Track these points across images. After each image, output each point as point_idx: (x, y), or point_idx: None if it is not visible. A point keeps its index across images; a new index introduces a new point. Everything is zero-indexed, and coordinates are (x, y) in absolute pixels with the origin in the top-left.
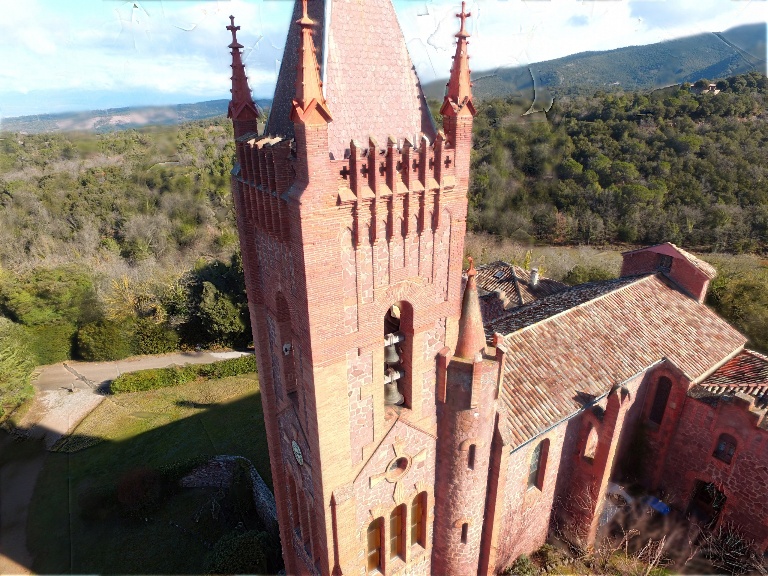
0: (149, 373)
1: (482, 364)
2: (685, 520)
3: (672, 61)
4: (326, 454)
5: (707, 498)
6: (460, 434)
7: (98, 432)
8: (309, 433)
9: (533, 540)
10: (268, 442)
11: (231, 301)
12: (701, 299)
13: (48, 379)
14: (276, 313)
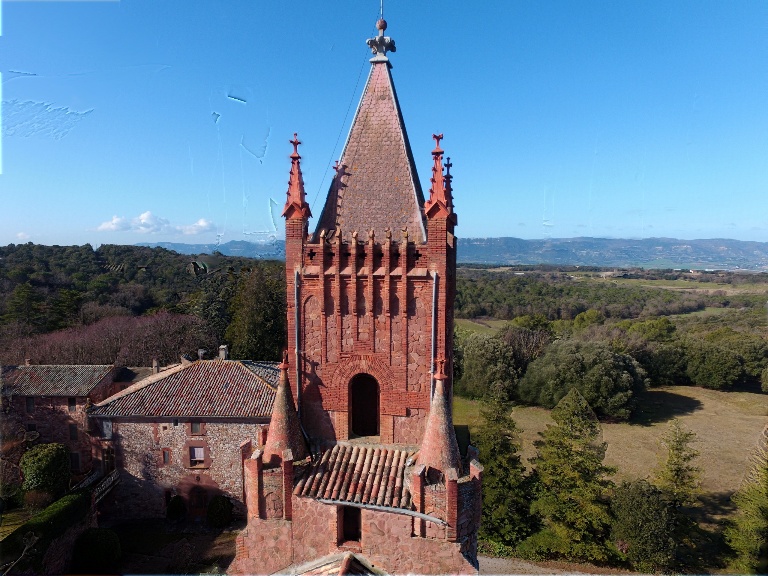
0: None
1: (259, 439)
2: None
3: None
4: None
5: None
6: None
7: None
8: None
9: None
10: None
11: None
12: None
13: None
14: None
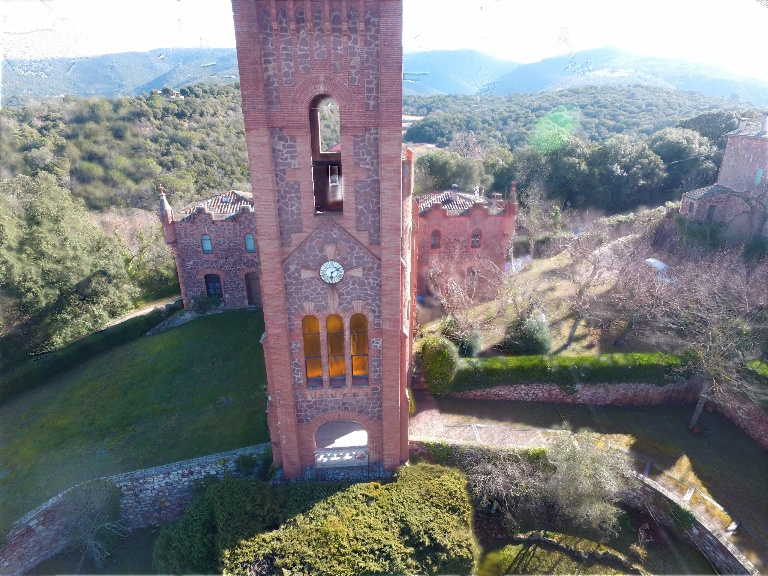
0: None
1: None
2: (429, 298)
3: (206, 42)
4: None
5: (429, 283)
6: (405, 220)
7: None
8: (383, 210)
9: None
10: (269, 305)
11: None
12: None
13: None
14: (305, 125)
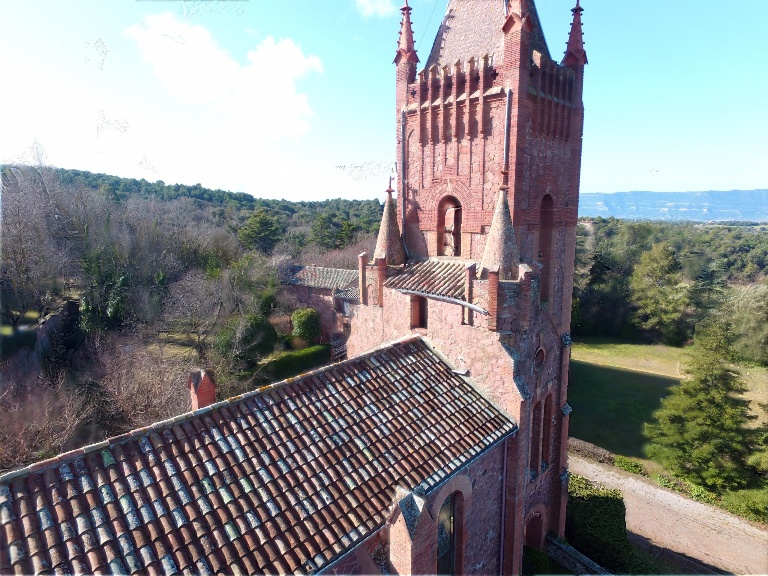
0: None
1: None
2: None
3: None
4: None
5: None
6: None
7: None
8: None
9: None
10: None
11: None
12: None
13: None
14: None
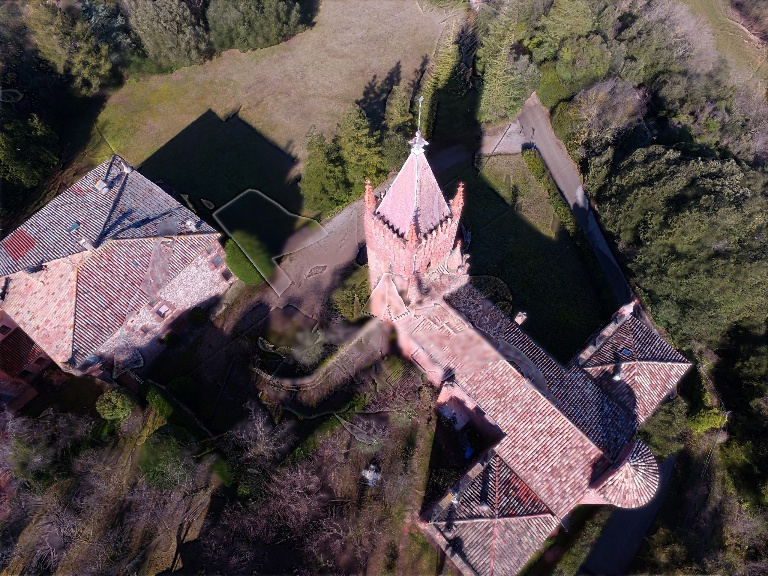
0: (538, 164)
1: None
2: (464, 466)
3: None
4: (369, 263)
5: None
6: None
7: (490, 168)
8: None
9: (432, 379)
10: None
11: (608, 173)
12: (592, 492)
13: (528, 114)
14: None
